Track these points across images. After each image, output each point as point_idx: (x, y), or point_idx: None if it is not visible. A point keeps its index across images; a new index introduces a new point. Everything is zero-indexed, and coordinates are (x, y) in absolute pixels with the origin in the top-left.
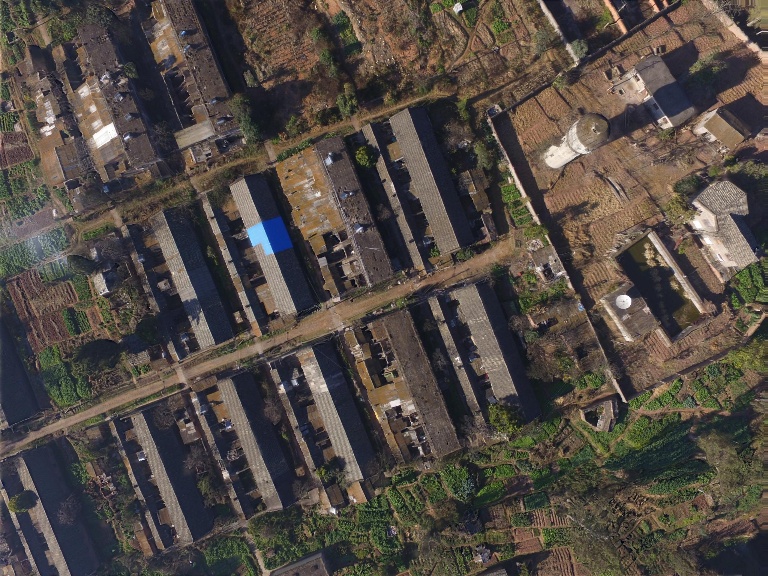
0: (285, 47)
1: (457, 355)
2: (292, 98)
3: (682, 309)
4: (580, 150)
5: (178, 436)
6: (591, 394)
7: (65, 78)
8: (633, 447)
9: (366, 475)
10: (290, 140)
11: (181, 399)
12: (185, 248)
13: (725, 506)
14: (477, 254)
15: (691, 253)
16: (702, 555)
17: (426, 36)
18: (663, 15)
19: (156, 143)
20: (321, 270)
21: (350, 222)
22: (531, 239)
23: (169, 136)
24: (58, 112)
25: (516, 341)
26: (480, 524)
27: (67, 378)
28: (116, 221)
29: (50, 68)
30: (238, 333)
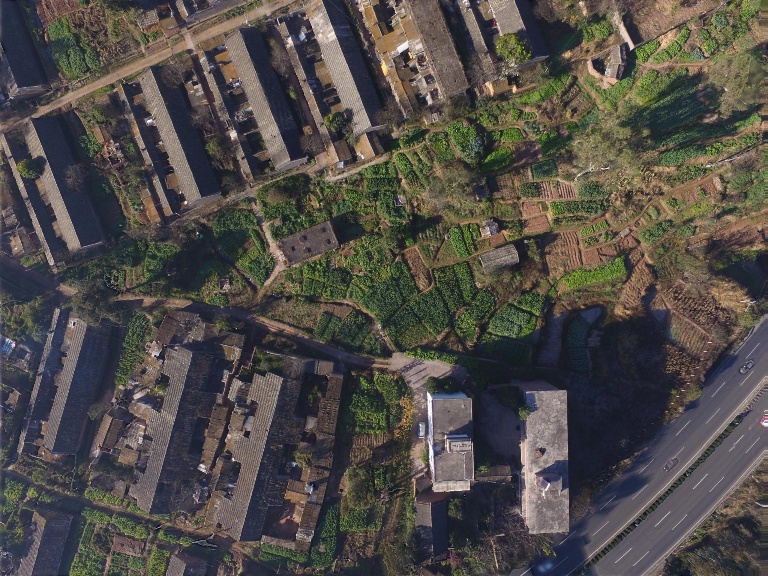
0: None
1: None
2: None
3: None
4: None
5: (186, 99)
6: (598, 46)
7: None
8: (641, 105)
9: (374, 123)
10: None
11: (189, 60)
12: None
13: (733, 196)
14: None
15: None
16: (710, 265)
17: None
18: None
19: None
20: None
21: None
22: None
23: None
24: None
25: None
26: (488, 190)
27: (76, 48)
28: None
29: None
30: None
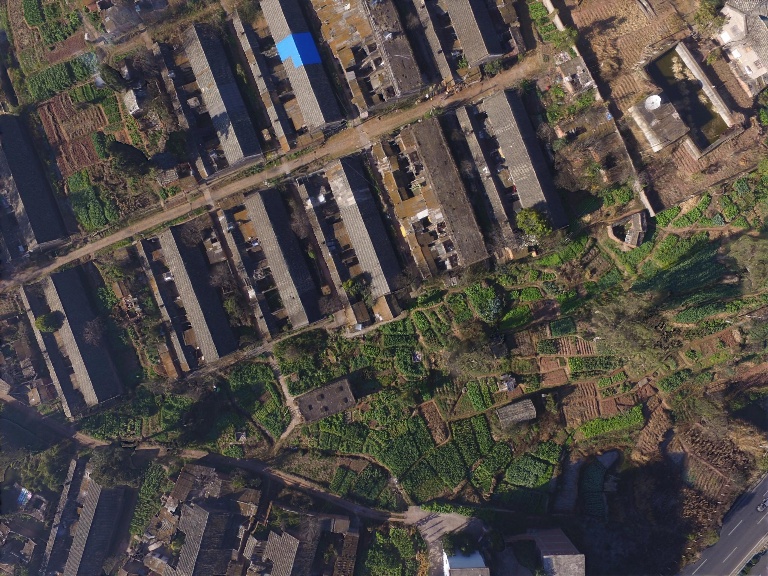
0: None
1: (485, 165)
2: None
3: (710, 123)
4: None
5: (205, 256)
6: (619, 211)
7: None
8: (661, 268)
9: (393, 288)
10: None
11: (208, 218)
12: (215, 63)
13: (752, 345)
14: (504, 70)
15: (719, 67)
16: (728, 406)
17: None
18: None
19: None
20: (349, 84)
21: (379, 30)
22: (559, 53)
23: None
24: None
25: (544, 153)
26: (506, 348)
27: (95, 201)
28: (147, 44)
29: None
30: (266, 151)
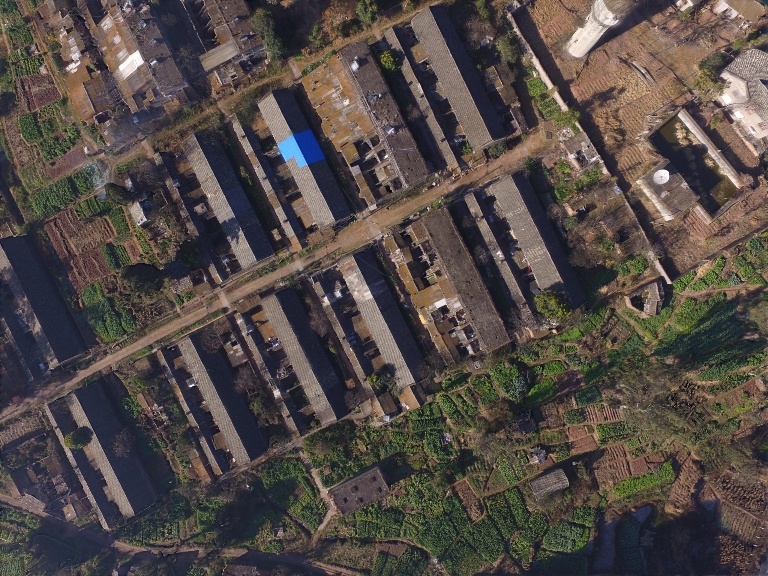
0: None
1: (498, 249)
2: (312, 13)
3: (719, 186)
4: (608, 20)
5: (226, 359)
6: (634, 280)
7: (87, 13)
8: (681, 331)
9: (417, 379)
10: (313, 55)
11: (226, 322)
12: (219, 169)
13: None
14: (508, 150)
15: (723, 129)
16: (756, 448)
17: None
18: None
19: (182, 66)
20: (355, 178)
21: (381, 125)
22: (561, 129)
23: (194, 59)
24: (83, 47)
25: (556, 231)
26: (534, 423)
27: (111, 313)
28: (147, 152)
29: (71, 7)
30: (277, 251)
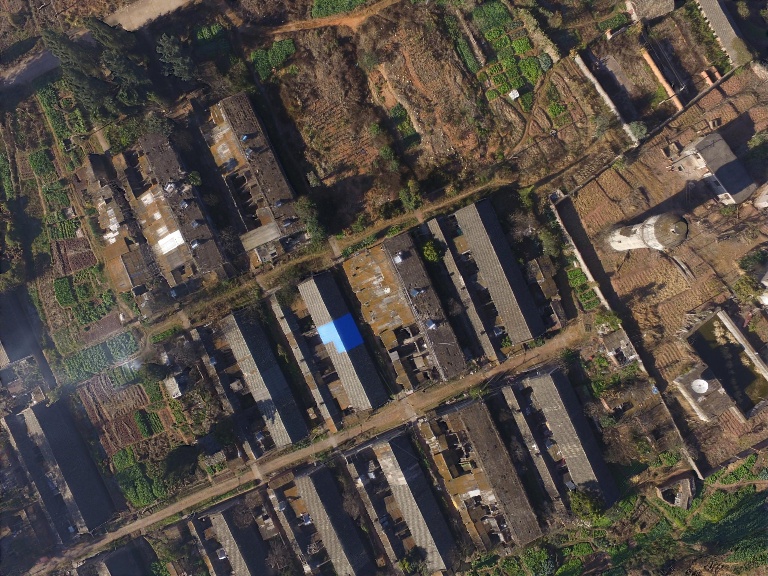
0: (344, 143)
1: (534, 443)
2: (354, 193)
3: (754, 384)
4: (657, 247)
5: (257, 532)
6: (666, 471)
7: (127, 186)
8: (709, 520)
9: (448, 564)
10: (354, 235)
11: (259, 496)
12: (256, 349)
13: None
14: (547, 339)
15: (760, 328)
16: None
17: (484, 124)
18: (716, 87)
19: (223, 248)
20: (393, 364)
21: (422, 318)
22: (601, 323)
23: (236, 240)
24: (122, 220)
25: (591, 425)
26: None
27: (142, 479)
28: (184, 323)
29: (110, 174)
30: (312, 428)
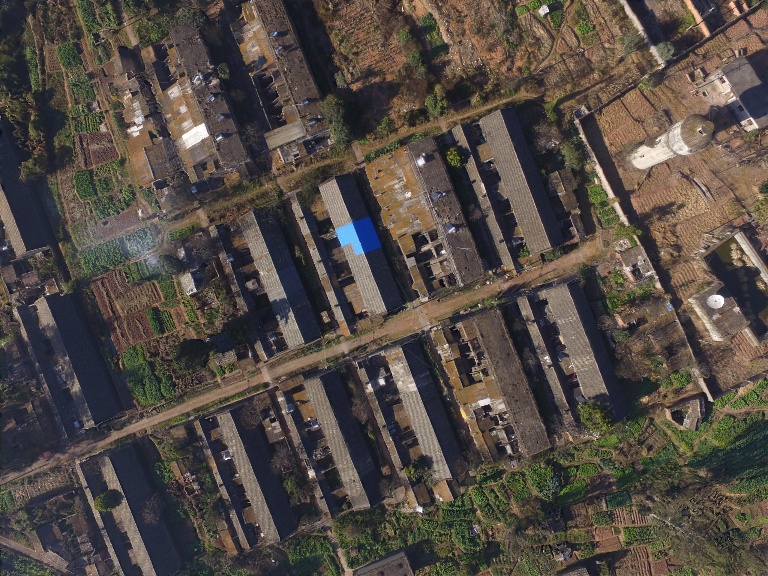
0: (373, 49)
1: (546, 354)
2: (380, 99)
3: (767, 309)
4: (682, 151)
5: (264, 435)
6: (676, 393)
7: (154, 79)
8: (716, 446)
9: (454, 474)
10: (377, 141)
11: (267, 398)
12: (274, 248)
13: None
14: (564, 254)
15: None
16: None
17: (513, 38)
18: (743, 18)
19: (247, 143)
20: (410, 270)
21: (442, 222)
22: (619, 239)
23: (260, 137)
24: (147, 112)
25: (604, 340)
26: (563, 523)
27: (151, 377)
28: (202, 221)
29: (137, 69)
30: (325, 332)
